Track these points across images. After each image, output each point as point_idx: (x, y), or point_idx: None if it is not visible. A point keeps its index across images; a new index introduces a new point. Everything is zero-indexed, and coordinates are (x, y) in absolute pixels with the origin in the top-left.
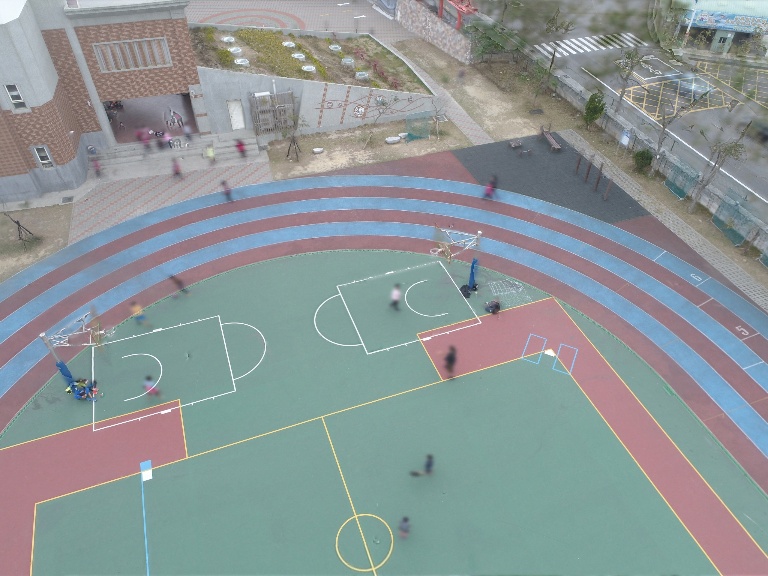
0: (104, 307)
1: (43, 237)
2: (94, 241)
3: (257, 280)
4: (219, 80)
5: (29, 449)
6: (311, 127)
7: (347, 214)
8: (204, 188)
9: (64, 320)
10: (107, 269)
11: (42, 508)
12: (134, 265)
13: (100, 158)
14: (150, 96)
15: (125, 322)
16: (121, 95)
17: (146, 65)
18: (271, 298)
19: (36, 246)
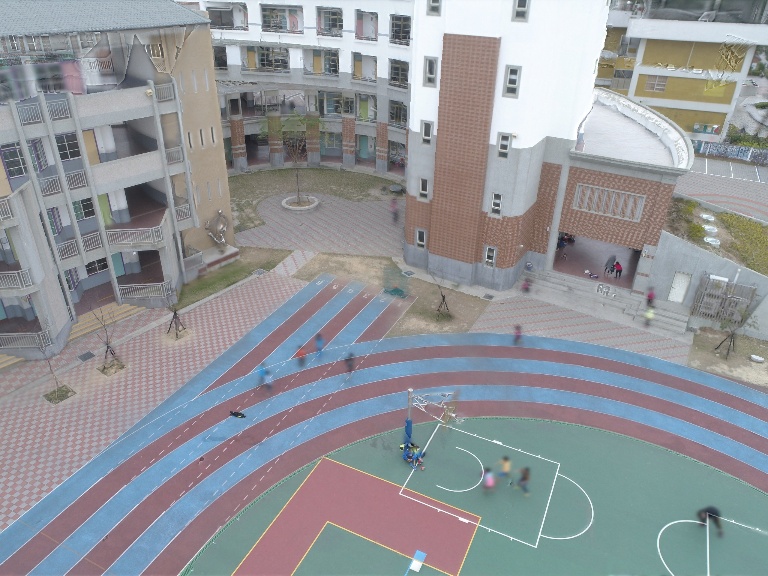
0: (466, 396)
1: (454, 317)
2: (490, 339)
3: (617, 453)
4: (679, 249)
5: (349, 474)
6: (760, 332)
7: (761, 442)
8: (610, 340)
9: (432, 389)
10: (487, 367)
11: (329, 529)
12: (510, 375)
13: (532, 275)
14: (603, 241)
15: (475, 419)
16: (578, 231)
17: (614, 214)
18: (622, 479)
19: (446, 321)
